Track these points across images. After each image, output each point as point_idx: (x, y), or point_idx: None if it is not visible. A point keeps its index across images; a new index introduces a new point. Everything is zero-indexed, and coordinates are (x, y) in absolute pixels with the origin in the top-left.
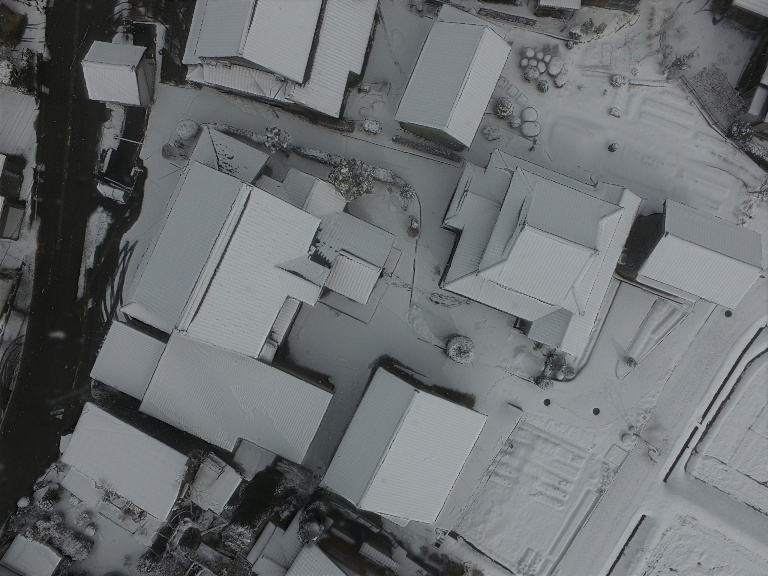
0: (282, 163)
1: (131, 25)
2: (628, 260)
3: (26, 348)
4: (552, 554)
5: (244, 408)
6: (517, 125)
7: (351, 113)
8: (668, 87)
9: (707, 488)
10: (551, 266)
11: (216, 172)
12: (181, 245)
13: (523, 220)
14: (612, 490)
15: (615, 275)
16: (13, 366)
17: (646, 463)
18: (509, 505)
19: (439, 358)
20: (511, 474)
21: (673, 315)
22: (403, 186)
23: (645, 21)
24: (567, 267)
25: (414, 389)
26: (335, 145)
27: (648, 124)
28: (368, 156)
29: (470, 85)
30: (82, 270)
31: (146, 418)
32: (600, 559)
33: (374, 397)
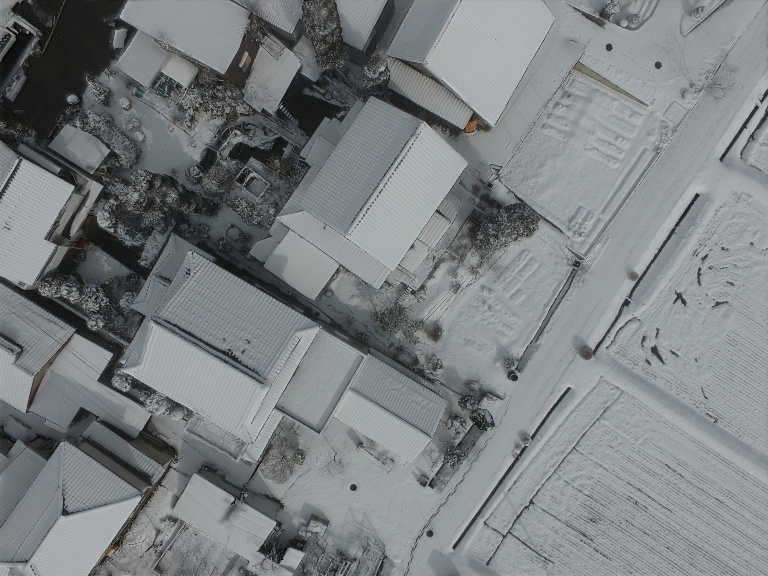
0: None
1: None
2: None
3: None
4: (604, 212)
5: None
6: None
7: None
8: None
9: (763, 174)
10: None
11: None
12: None
13: None
14: (667, 160)
15: None
16: None
17: (704, 134)
18: (563, 160)
19: None
20: (567, 127)
21: None
22: None
23: None
24: None
25: None
26: None
27: None
28: None
29: None
30: None
31: None
32: (651, 229)
33: None
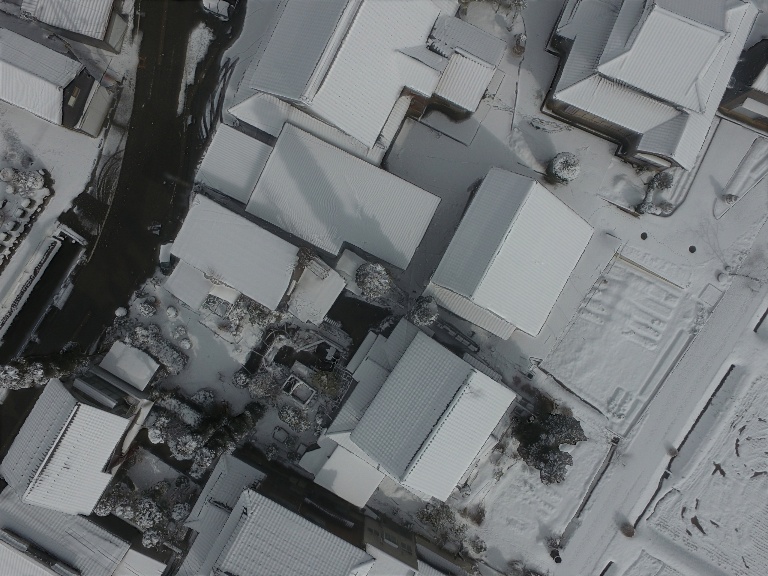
0: None
1: None
2: (733, 90)
3: (125, 163)
4: (643, 394)
5: (358, 198)
6: None
7: None
8: None
9: None
10: (676, 55)
11: None
12: (303, 25)
13: (651, 4)
14: (703, 335)
15: None
16: (111, 181)
17: (738, 309)
18: (601, 343)
19: None
20: (604, 311)
21: None
22: None
23: None
24: (693, 56)
25: (532, 180)
26: None
27: None
28: None
29: None
30: (183, 86)
31: (253, 218)
32: (689, 405)
33: (487, 194)
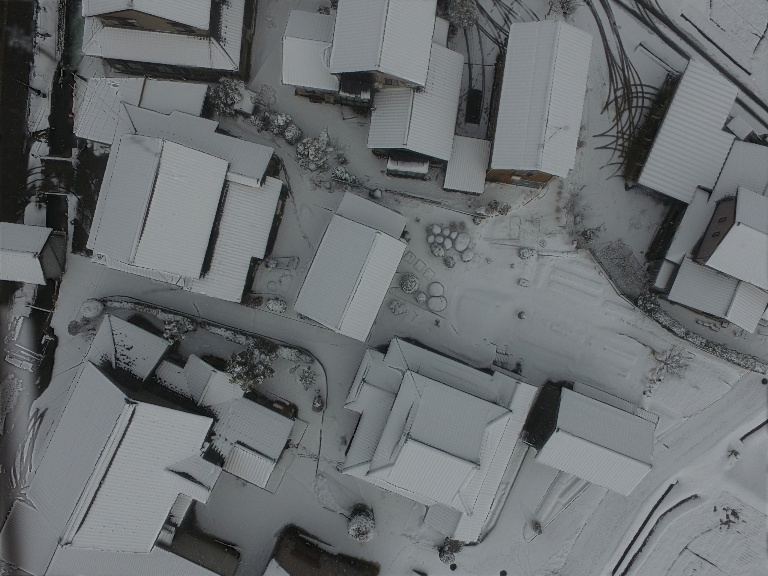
0: (190, 336)
1: (44, 194)
2: (533, 431)
3: None
4: None
5: None
6: (423, 301)
7: (259, 287)
8: (577, 257)
9: None
10: (437, 473)
11: (106, 379)
12: (71, 449)
13: (408, 430)
14: None
15: None
16: None
17: None
18: None
19: (345, 527)
20: None
21: (580, 480)
22: (303, 371)
23: (554, 193)
24: (452, 475)
25: None
26: (243, 317)
27: (557, 293)
28: (276, 328)
29: (363, 287)
30: None
31: None
32: None
33: None
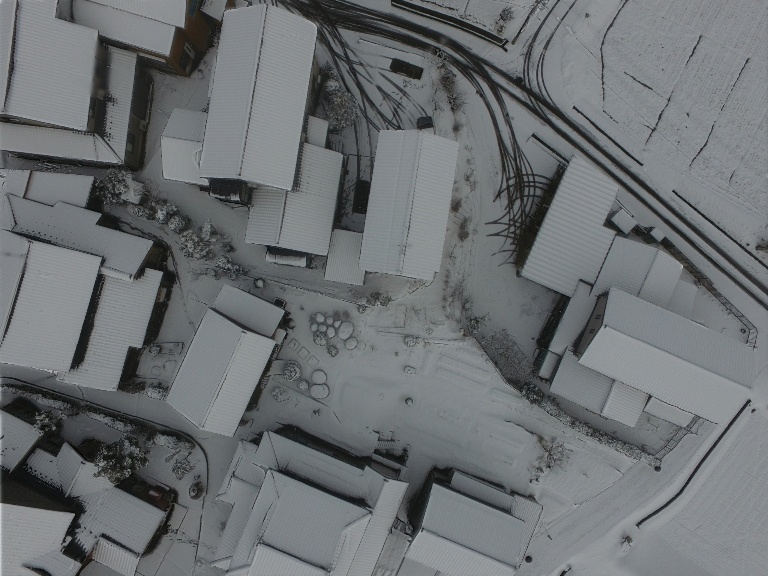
0: (73, 419)
1: None
2: (414, 521)
3: None
4: None
5: None
6: (304, 389)
7: (143, 371)
8: (464, 345)
9: None
10: (292, 575)
11: None
12: None
13: (262, 533)
14: None
15: (409, 526)
16: None
17: None
18: None
19: None
20: None
21: None
22: (176, 461)
23: (441, 282)
24: None
25: None
26: (127, 401)
27: (444, 380)
28: (159, 413)
29: (228, 384)
30: None
31: None
32: None
33: None
